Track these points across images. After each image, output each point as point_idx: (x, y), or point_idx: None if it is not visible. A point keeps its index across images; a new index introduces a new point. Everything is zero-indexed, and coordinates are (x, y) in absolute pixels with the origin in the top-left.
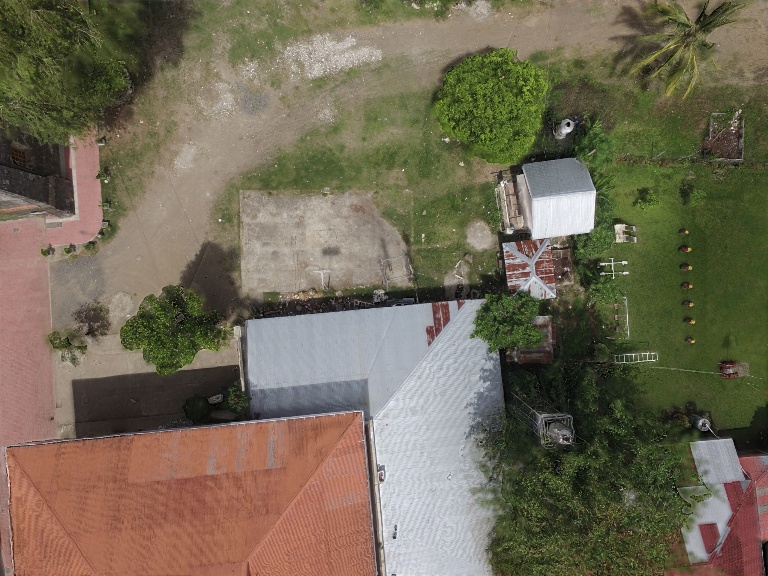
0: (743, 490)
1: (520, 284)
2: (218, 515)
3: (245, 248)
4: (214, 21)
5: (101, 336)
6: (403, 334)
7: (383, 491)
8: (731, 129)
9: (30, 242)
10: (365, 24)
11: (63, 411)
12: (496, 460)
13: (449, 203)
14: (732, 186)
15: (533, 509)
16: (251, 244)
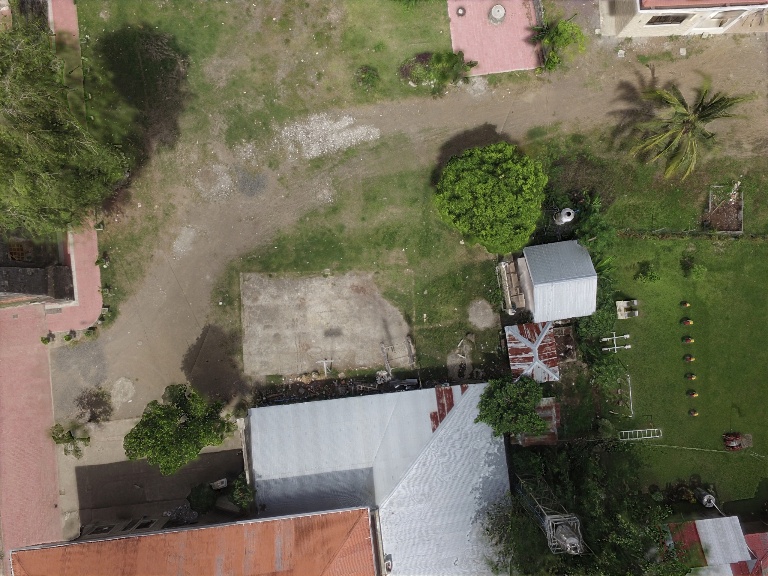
0: (749, 570)
1: (523, 368)
2: None
3: (246, 331)
4: (210, 102)
5: (103, 422)
6: (407, 420)
7: None
8: (730, 201)
9: (30, 329)
10: (362, 103)
11: (67, 498)
12: (502, 544)
13: (450, 282)
14: (732, 257)
15: None
16: (252, 327)
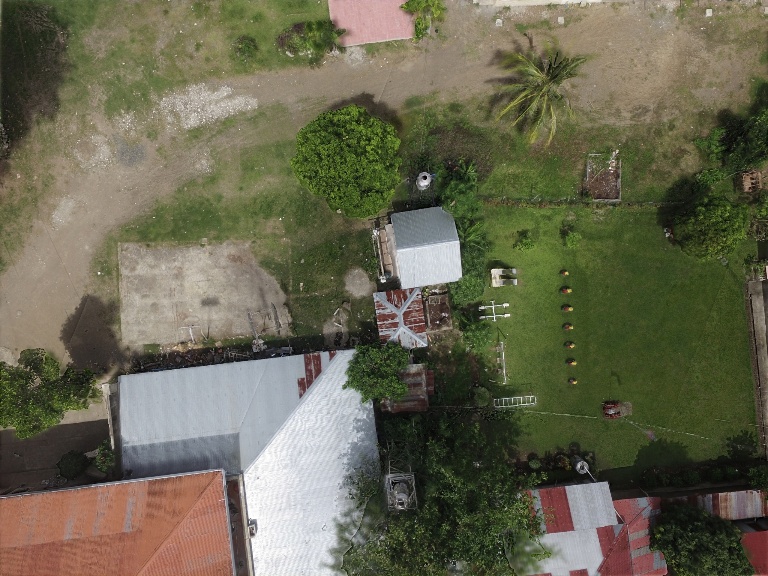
0: (615, 534)
1: (390, 334)
2: None
3: (124, 301)
4: (89, 73)
5: None
6: (275, 387)
7: (255, 545)
8: (609, 169)
9: None
10: (240, 73)
11: None
12: None
13: (327, 251)
14: (612, 226)
15: None
16: (130, 296)
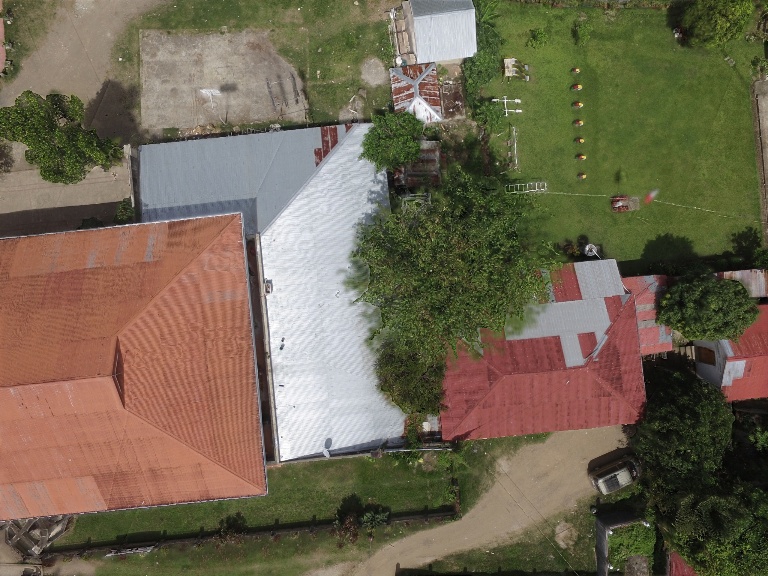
0: (622, 303)
1: (405, 106)
2: (93, 300)
3: (145, 85)
4: None
5: (5, 173)
6: (292, 156)
7: (270, 304)
8: None
9: None
10: None
11: None
12: None
13: (344, 40)
14: (622, 27)
15: (373, 251)
16: (150, 82)
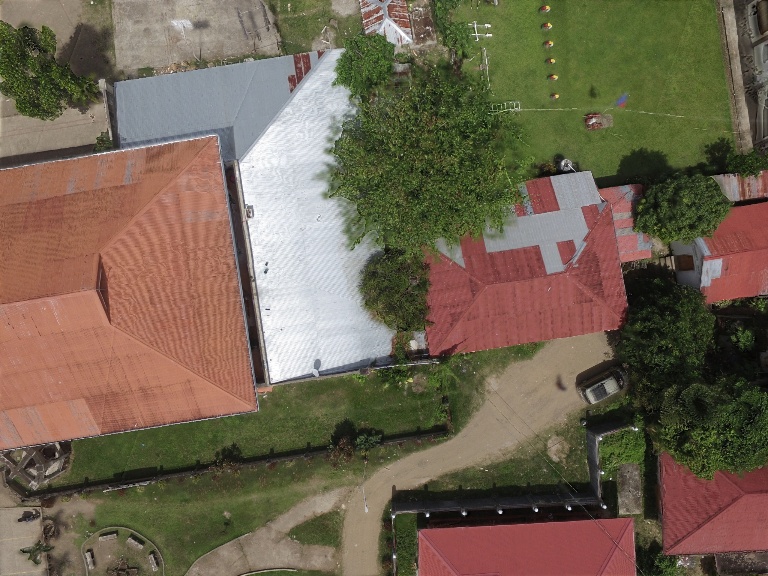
0: (599, 211)
1: (375, 29)
2: (74, 223)
3: (117, 27)
4: None
5: None
6: (266, 84)
7: (252, 229)
8: None
9: None
10: None
11: None
12: None
13: None
14: None
15: (345, 143)
16: (123, 23)
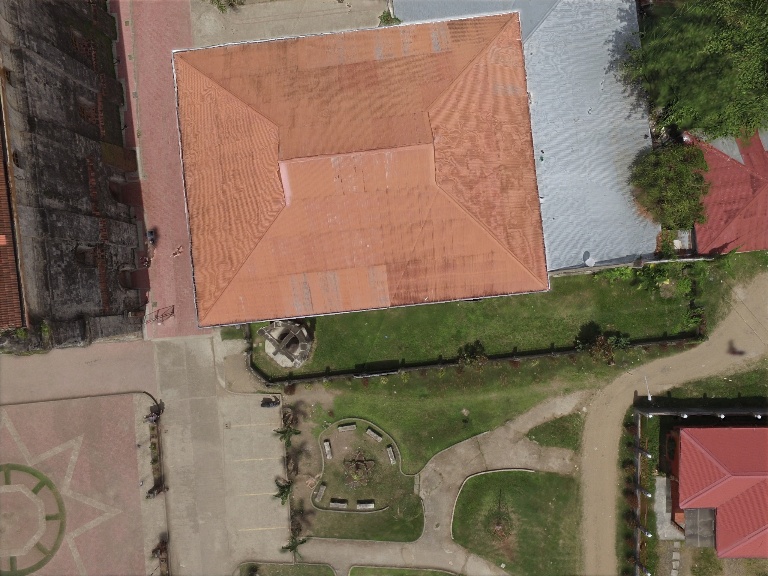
0: None
1: None
2: (392, 85)
3: None
4: None
5: (238, 6)
6: None
7: None
8: None
9: None
10: None
11: None
12: (634, 97)
13: None
14: None
15: None
16: None
